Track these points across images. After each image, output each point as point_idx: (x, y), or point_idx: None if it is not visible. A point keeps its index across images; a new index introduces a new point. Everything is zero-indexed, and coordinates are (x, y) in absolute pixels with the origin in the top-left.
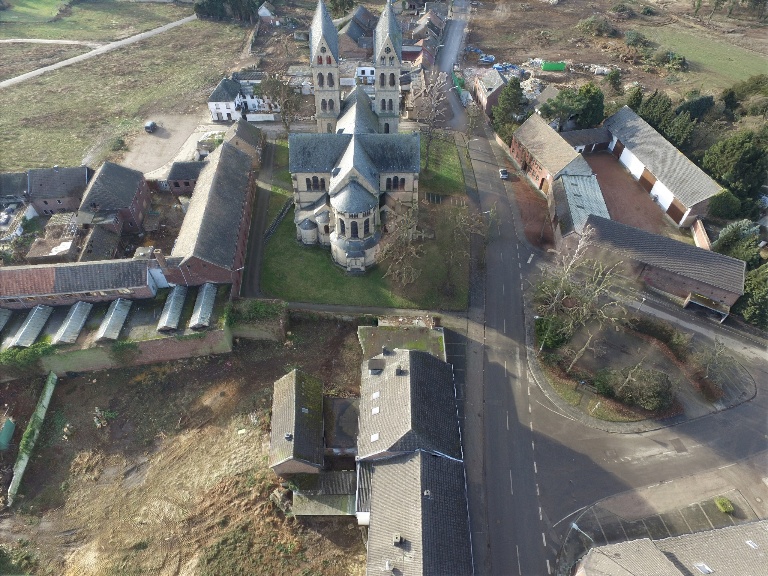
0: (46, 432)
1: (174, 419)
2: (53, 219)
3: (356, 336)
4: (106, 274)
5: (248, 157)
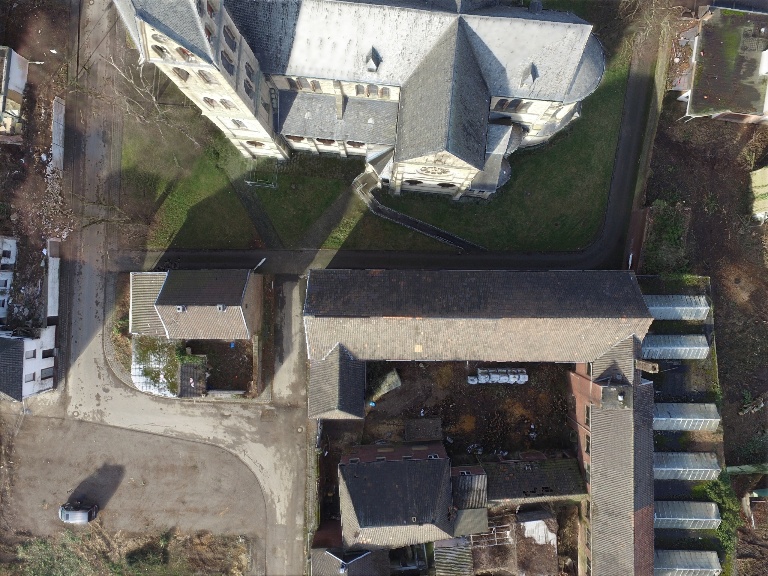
0: (762, 457)
1: (763, 328)
2: (454, 574)
3: (671, 126)
4: (642, 441)
5: (319, 276)
